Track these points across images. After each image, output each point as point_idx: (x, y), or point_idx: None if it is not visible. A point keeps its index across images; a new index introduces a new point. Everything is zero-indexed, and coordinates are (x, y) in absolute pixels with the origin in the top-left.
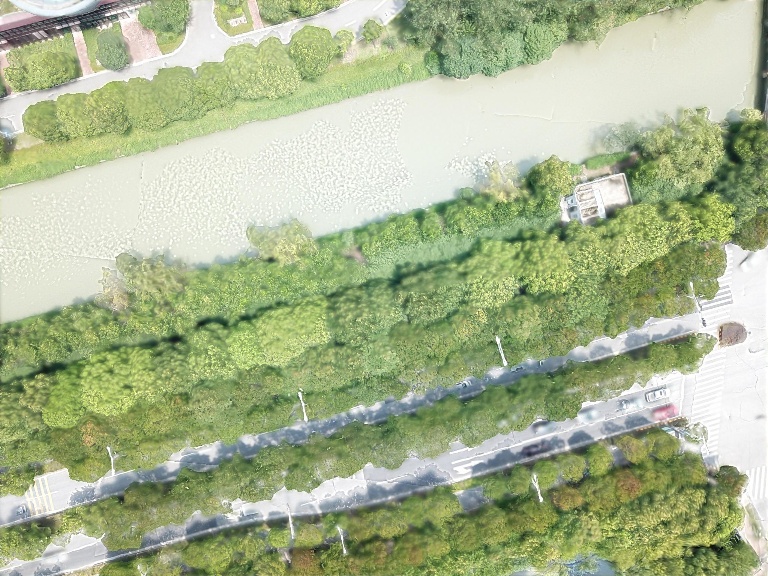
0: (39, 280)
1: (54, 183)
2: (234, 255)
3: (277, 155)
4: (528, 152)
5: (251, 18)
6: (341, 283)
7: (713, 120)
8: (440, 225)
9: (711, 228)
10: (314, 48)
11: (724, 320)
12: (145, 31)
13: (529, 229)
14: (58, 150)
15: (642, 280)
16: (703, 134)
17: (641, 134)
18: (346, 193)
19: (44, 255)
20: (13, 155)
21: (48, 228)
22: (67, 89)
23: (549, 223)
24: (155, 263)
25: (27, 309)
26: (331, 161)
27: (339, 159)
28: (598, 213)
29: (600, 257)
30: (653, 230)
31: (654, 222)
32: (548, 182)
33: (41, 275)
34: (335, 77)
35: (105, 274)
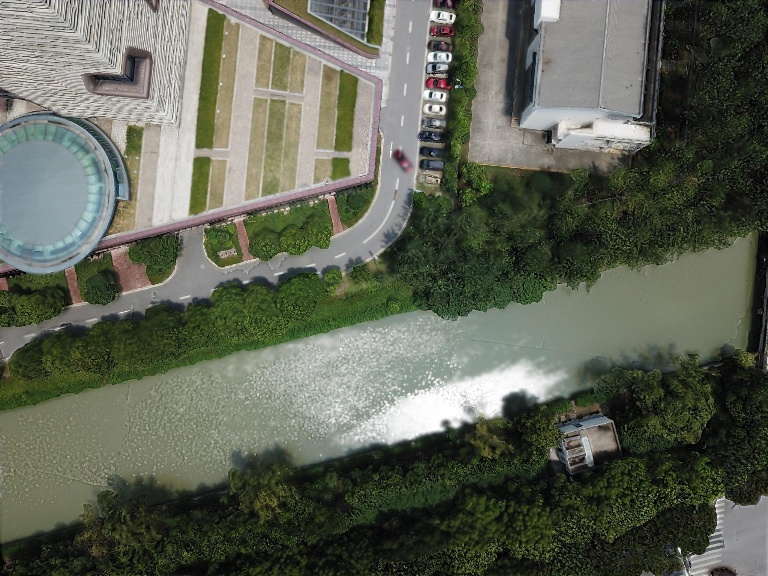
0: (22, 499)
1: (41, 404)
2: (217, 482)
3: (264, 378)
4: (517, 383)
5: (241, 250)
6: (322, 535)
7: (707, 349)
8: (424, 477)
9: (700, 495)
10: (300, 305)
11: (715, 565)
12: (135, 261)
13: (515, 476)
14: (45, 379)
15: (629, 543)
16: (692, 400)
17: (632, 372)
18: (332, 418)
19: (28, 473)
20: (0, 383)
21: (33, 447)
22: (56, 317)
23: (536, 470)
24: (135, 512)
25: (9, 533)
26: (318, 386)
27: (326, 384)
28: (586, 461)
29: (585, 526)
30: (640, 498)
31: (641, 489)
32: (534, 441)
33: (25, 494)
34: (323, 310)
35: (86, 514)
